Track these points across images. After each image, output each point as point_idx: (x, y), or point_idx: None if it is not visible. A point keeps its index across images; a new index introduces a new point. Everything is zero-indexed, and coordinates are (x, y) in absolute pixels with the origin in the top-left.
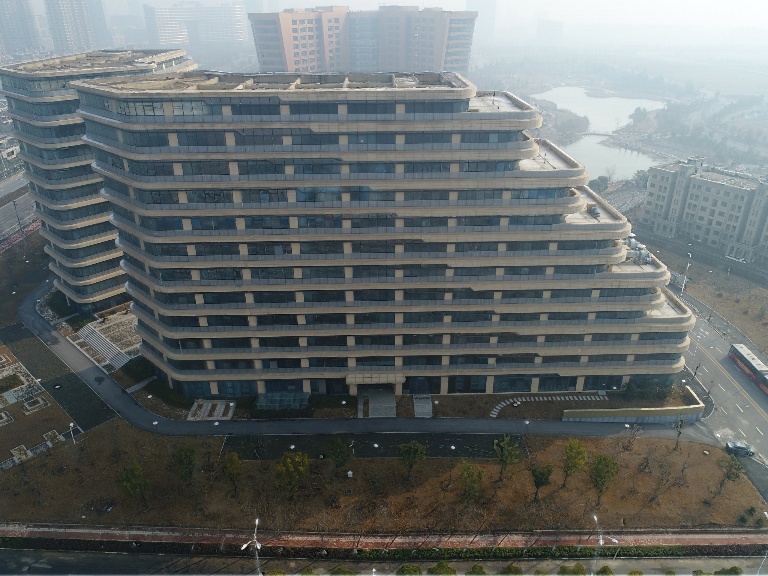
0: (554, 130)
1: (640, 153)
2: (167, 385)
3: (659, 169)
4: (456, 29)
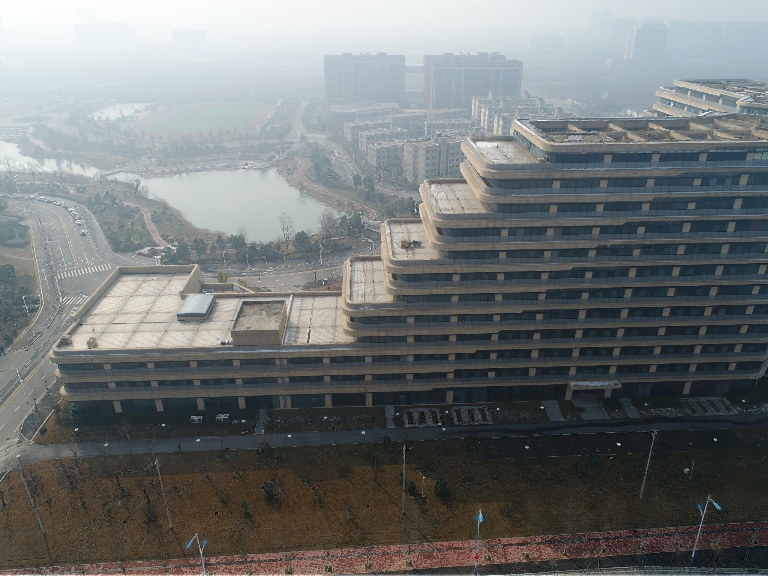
0: None
1: (193, 173)
2: None
3: (431, 146)
4: None
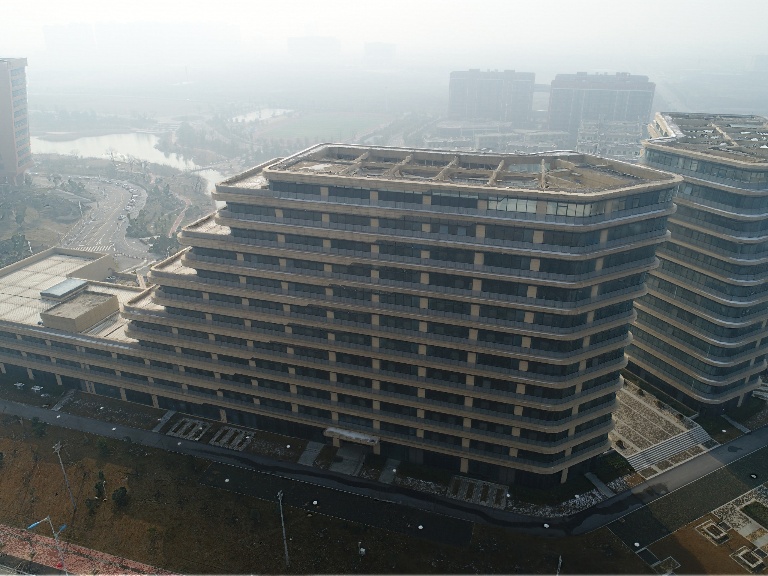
0: (164, 176)
1: None
2: (736, 408)
3: None
4: (14, 82)
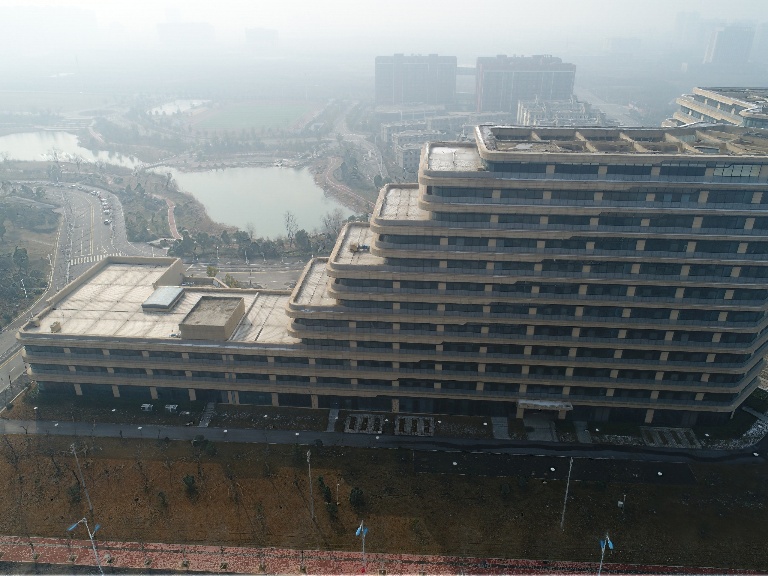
0: None
1: (229, 168)
2: None
3: None
4: None
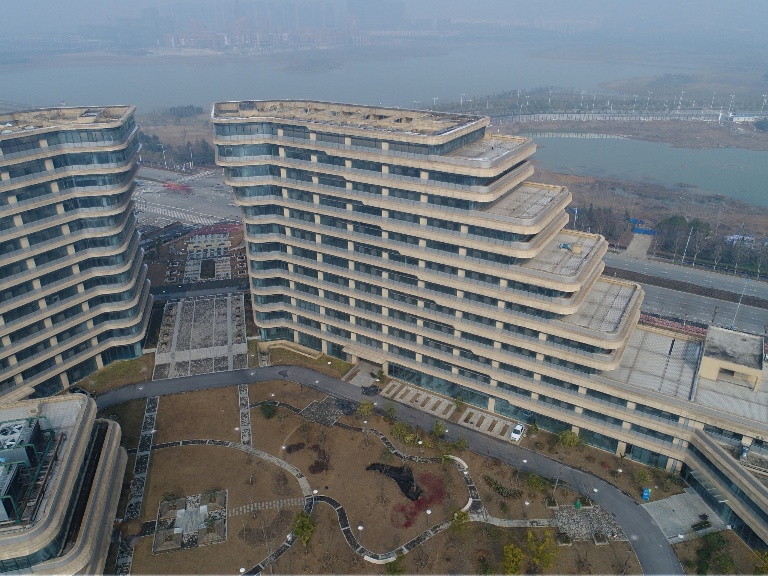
0: None
1: None
2: None
3: None
4: None
